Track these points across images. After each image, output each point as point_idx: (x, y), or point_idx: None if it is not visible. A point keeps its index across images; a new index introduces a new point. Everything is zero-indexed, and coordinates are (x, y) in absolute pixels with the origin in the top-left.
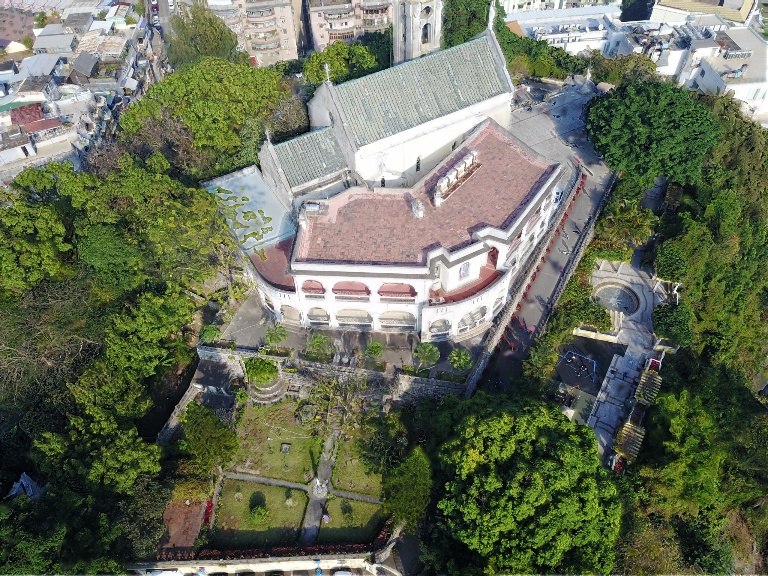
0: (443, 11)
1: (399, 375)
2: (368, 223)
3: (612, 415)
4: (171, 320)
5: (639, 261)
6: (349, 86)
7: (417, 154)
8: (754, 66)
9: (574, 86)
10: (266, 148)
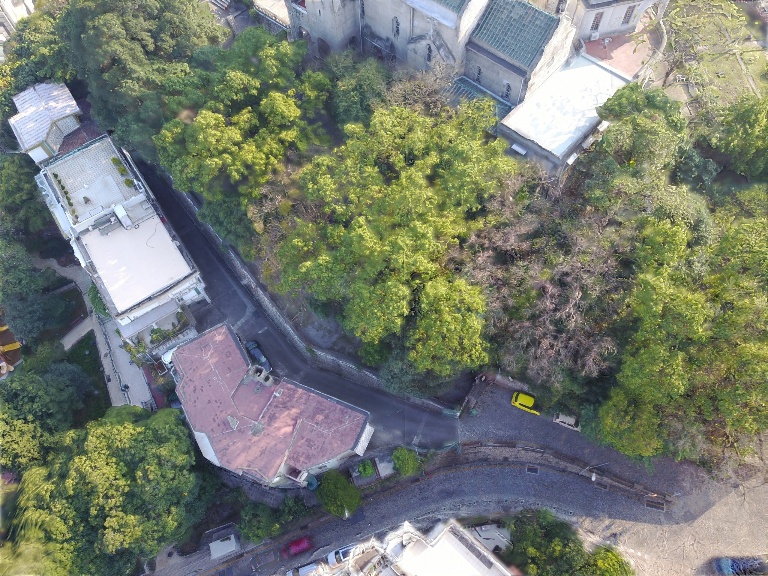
0: None
1: None
2: None
3: None
4: None
5: None
6: None
7: None
8: None
9: None
10: None
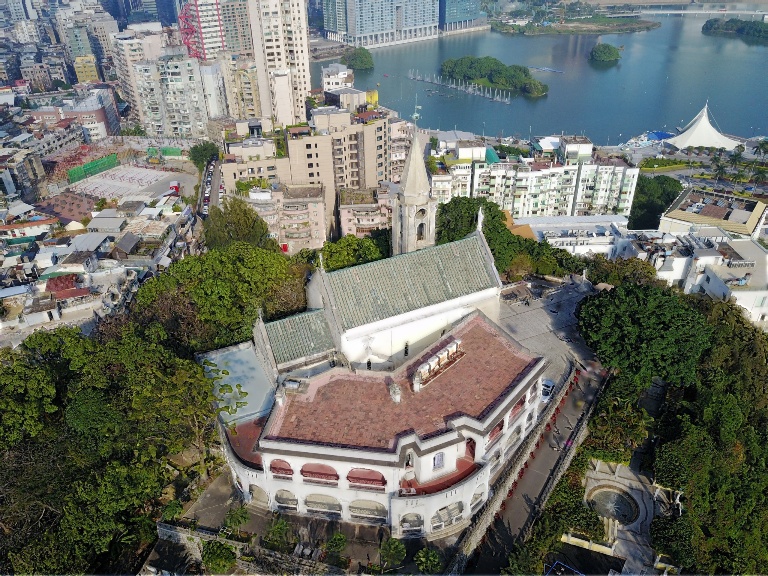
0: (447, 213)
1: (362, 574)
2: (345, 404)
3: None
4: (133, 492)
5: (639, 464)
6: (342, 273)
7: (405, 340)
8: (758, 275)
9: (572, 285)
10: (258, 325)
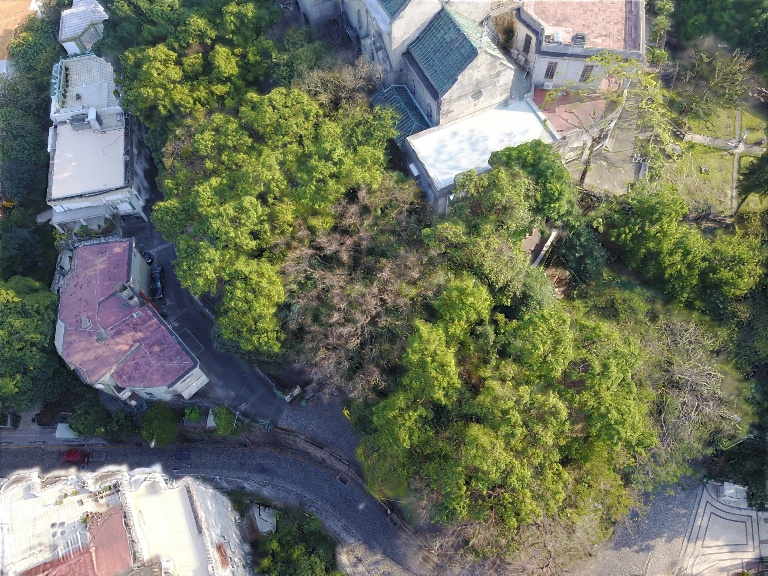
0: None
1: None
2: (572, 5)
3: None
4: None
5: None
6: None
7: None
8: None
9: None
10: (479, 58)
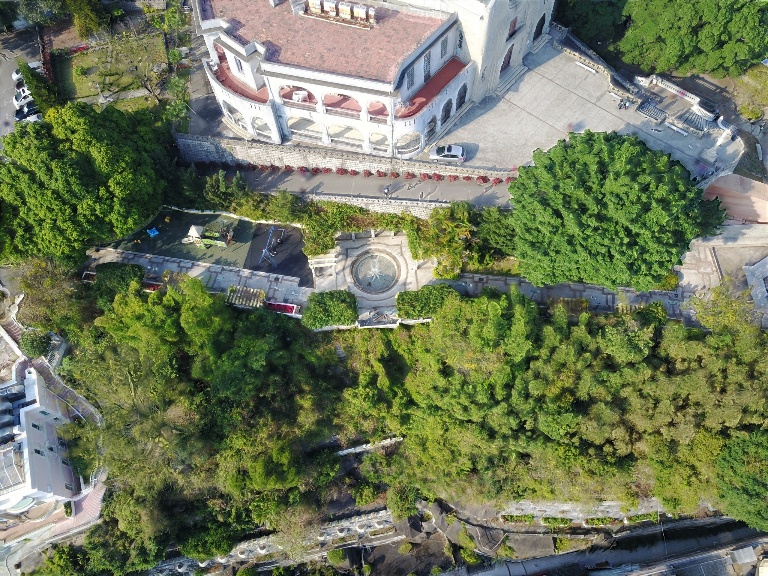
0: None
1: None
2: None
3: (226, 283)
4: None
5: None
6: None
7: None
8: None
9: None
10: None
